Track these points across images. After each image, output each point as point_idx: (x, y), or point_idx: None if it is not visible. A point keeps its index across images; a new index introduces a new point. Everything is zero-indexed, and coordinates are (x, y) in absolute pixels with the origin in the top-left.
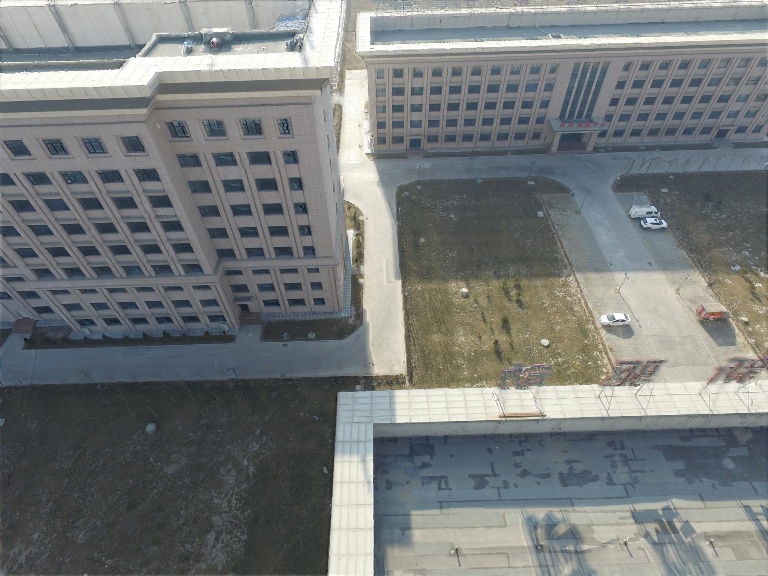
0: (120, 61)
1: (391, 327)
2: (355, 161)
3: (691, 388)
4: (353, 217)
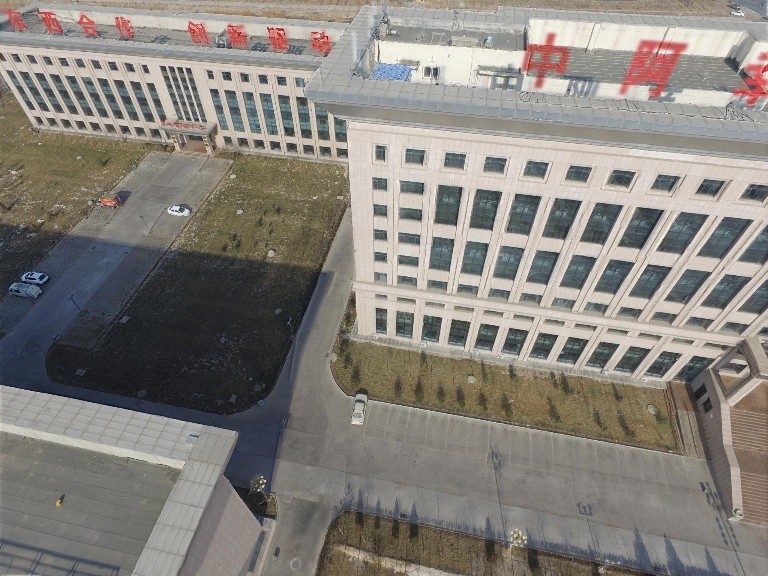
0: (571, 81)
1: (346, 237)
2: (303, 499)
3: (249, 55)
4: (345, 347)
